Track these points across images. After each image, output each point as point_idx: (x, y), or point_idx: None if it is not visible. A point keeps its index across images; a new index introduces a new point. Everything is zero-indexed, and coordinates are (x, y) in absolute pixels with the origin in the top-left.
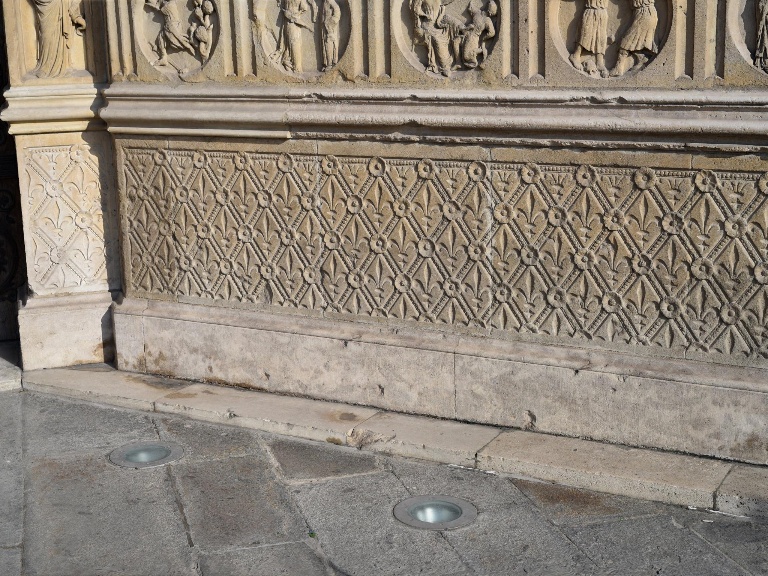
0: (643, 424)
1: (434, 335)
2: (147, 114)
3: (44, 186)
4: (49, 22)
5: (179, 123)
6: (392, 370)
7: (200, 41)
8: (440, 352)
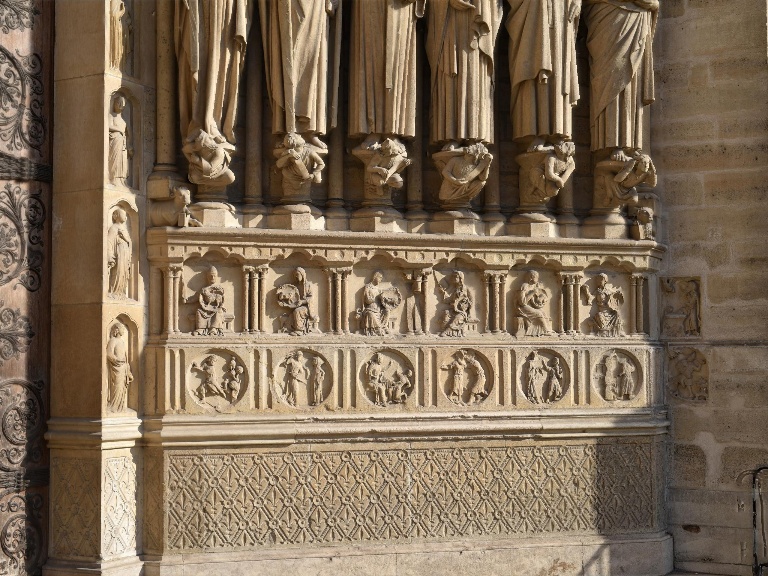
0: (494, 574)
1: (381, 546)
2: (199, 433)
3: (111, 484)
4: (122, 377)
5: (220, 438)
6: (360, 570)
7: (233, 389)
8: (388, 554)
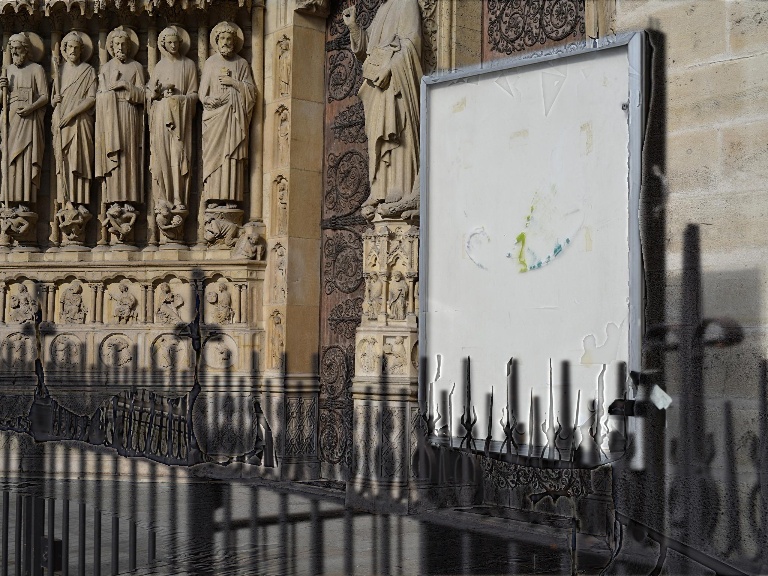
0: None
1: None
2: None
3: None
4: None
5: None
6: None
7: None
8: None
